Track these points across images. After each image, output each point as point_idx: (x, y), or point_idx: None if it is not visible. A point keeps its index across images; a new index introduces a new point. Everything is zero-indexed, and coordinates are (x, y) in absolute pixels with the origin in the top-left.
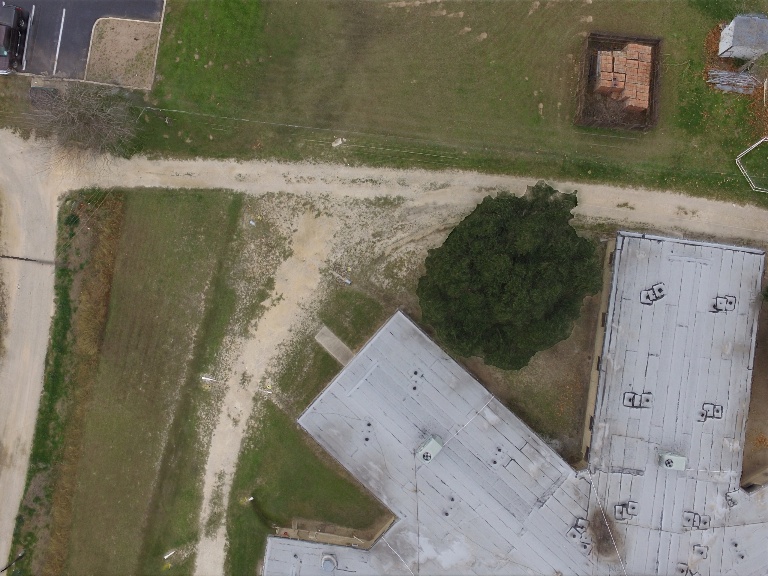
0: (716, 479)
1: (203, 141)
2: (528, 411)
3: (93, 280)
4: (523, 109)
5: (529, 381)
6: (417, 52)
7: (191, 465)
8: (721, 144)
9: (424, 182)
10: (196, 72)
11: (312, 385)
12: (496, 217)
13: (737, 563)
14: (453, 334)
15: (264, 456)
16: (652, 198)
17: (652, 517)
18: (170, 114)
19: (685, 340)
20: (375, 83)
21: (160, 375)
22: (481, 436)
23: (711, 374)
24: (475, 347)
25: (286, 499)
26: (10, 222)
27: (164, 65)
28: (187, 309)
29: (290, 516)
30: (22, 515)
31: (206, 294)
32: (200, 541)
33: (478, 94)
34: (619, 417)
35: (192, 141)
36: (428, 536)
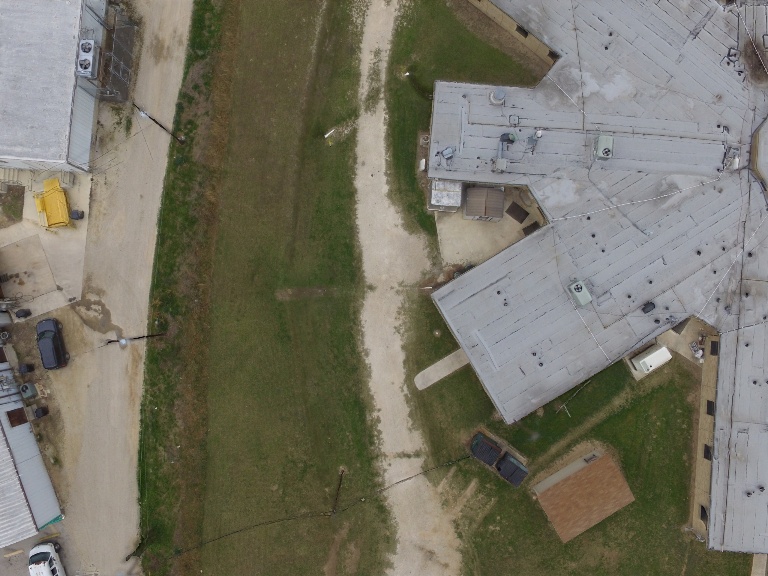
0: None
1: None
2: None
3: None
4: None
5: None
6: None
7: (346, 46)
8: None
9: None
10: None
11: None
12: None
13: None
14: None
15: (417, 33)
16: None
17: None
18: None
19: None
20: None
21: None
22: None
23: None
24: None
25: (441, 71)
26: None
27: None
28: None
29: None
30: (181, 102)
31: None
32: (359, 116)
33: None
34: None
35: None
36: (589, 71)
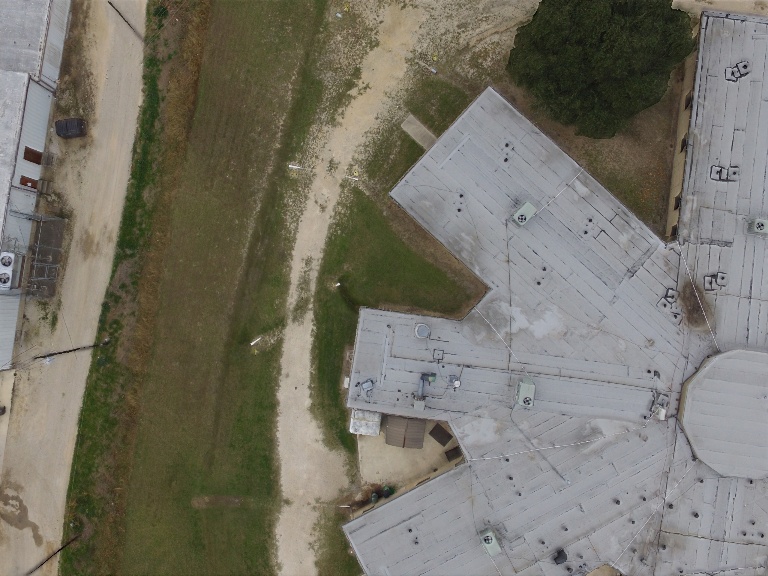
0: None
1: None
2: None
3: (181, 69)
4: None
5: (613, 168)
6: None
7: (278, 251)
8: None
9: None
10: None
11: (398, 172)
12: None
13: None
14: (551, 89)
15: (351, 242)
16: None
17: (741, 286)
18: None
19: None
20: None
21: (247, 163)
22: (571, 208)
23: None
24: (572, 103)
25: (373, 284)
26: (99, 15)
27: None
28: (274, 98)
29: (377, 301)
30: (108, 302)
31: (293, 84)
32: (287, 326)
33: None
34: (707, 190)
35: None
36: (520, 306)
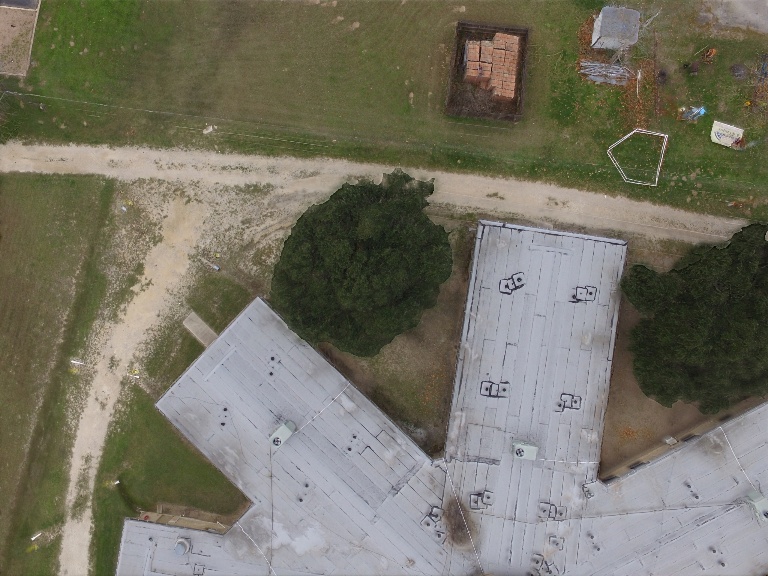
0: (573, 470)
1: (77, 127)
2: (393, 399)
3: None
4: (393, 98)
5: (395, 369)
6: (289, 41)
7: (59, 448)
8: (593, 135)
9: (294, 170)
10: (71, 59)
11: (179, 370)
12: (340, 203)
13: (593, 555)
14: (299, 319)
15: (130, 440)
16: (522, 188)
17: (506, 507)
18: (45, 100)
19: (543, 330)
20: (247, 71)
21: (30, 358)
22: (337, 423)
23: (570, 364)
24: (321, 332)
25: (151, 483)
26: None
27: (39, 52)
28: (58, 293)
29: (155, 500)
30: None
31: (77, 278)
32: (66, 523)
33: (349, 83)
34: (476, 406)
35: (66, 127)
36: (282, 522)
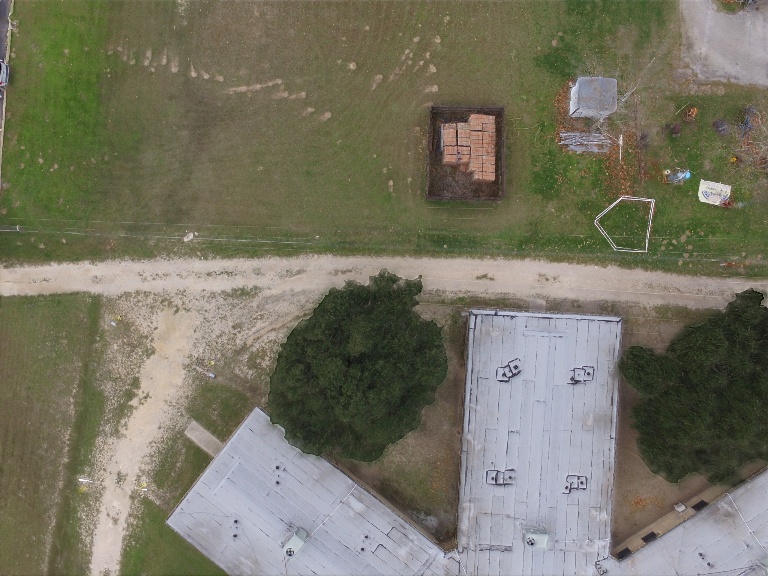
0: (585, 549)
1: (57, 246)
2: (401, 490)
3: None
4: (373, 188)
5: (399, 460)
6: (262, 138)
7: (76, 565)
8: (578, 206)
9: (280, 270)
10: (42, 177)
11: (186, 479)
12: (329, 318)
13: None
14: (299, 436)
15: (146, 552)
16: (511, 267)
17: None
18: (20, 222)
19: (543, 415)
20: (222, 173)
21: (37, 480)
22: (347, 524)
23: (573, 446)
24: (323, 446)
25: None
26: None
27: (9, 173)
28: (57, 414)
29: None
30: None
31: (75, 397)
32: None
33: (326, 176)
34: (483, 495)
35: (46, 247)
36: None
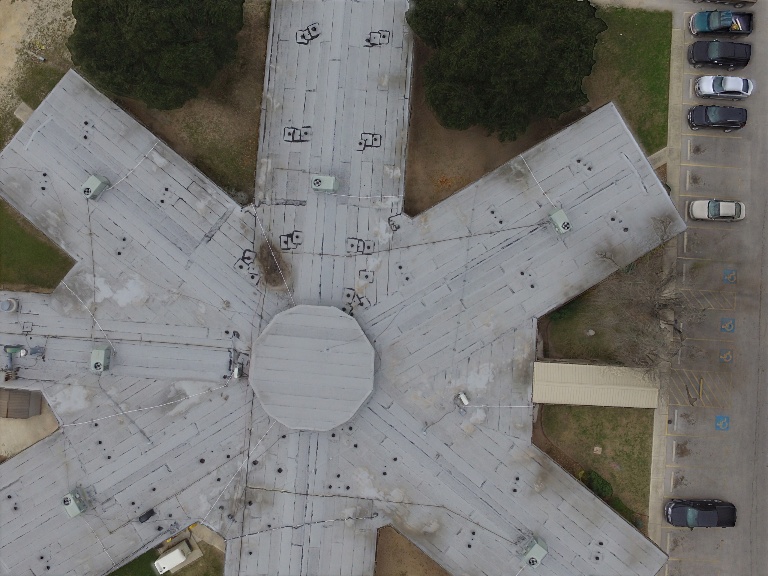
0: (378, 205)
1: None
2: (213, 167)
3: None
4: None
5: (213, 138)
6: None
7: None
8: None
9: None
10: None
11: None
12: None
13: (403, 285)
14: (93, 65)
15: None
16: None
17: (314, 243)
18: None
19: (338, 73)
20: None
21: None
22: (150, 179)
23: (368, 105)
24: (115, 77)
25: None
26: None
27: None
28: None
29: None
30: None
31: None
32: None
33: None
34: (280, 151)
35: None
36: (104, 276)
